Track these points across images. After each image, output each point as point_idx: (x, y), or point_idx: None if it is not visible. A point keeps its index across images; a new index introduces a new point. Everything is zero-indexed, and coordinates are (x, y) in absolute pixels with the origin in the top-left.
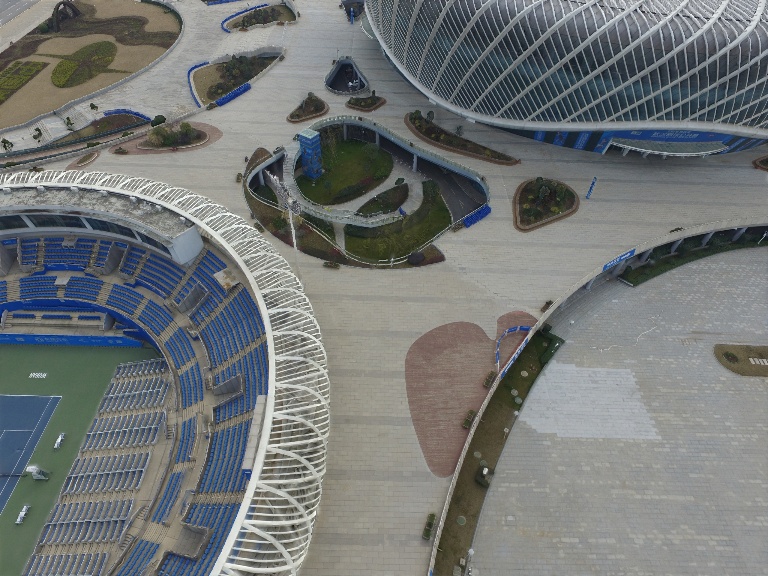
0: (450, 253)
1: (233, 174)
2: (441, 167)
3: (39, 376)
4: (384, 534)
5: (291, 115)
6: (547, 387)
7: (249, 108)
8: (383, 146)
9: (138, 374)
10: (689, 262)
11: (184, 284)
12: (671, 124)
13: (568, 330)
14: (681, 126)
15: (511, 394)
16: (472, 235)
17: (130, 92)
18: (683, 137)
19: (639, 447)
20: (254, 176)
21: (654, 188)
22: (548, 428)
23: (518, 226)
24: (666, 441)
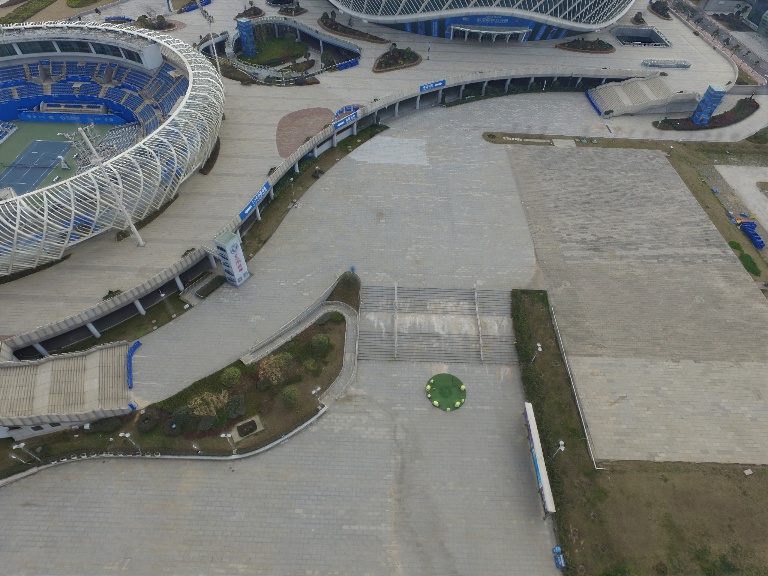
0: (324, 81)
1: (191, 44)
2: (341, 51)
3: None
4: (248, 174)
5: (236, 16)
6: (370, 145)
7: None
8: (303, 41)
9: (122, 131)
10: (491, 98)
11: (151, 83)
12: (484, 9)
13: (394, 124)
14: (490, 10)
15: (347, 148)
16: (342, 74)
17: (124, 9)
18: (498, 22)
19: (414, 167)
20: (206, 48)
21: (477, 56)
22: (363, 159)
23: (374, 70)
24: (431, 165)
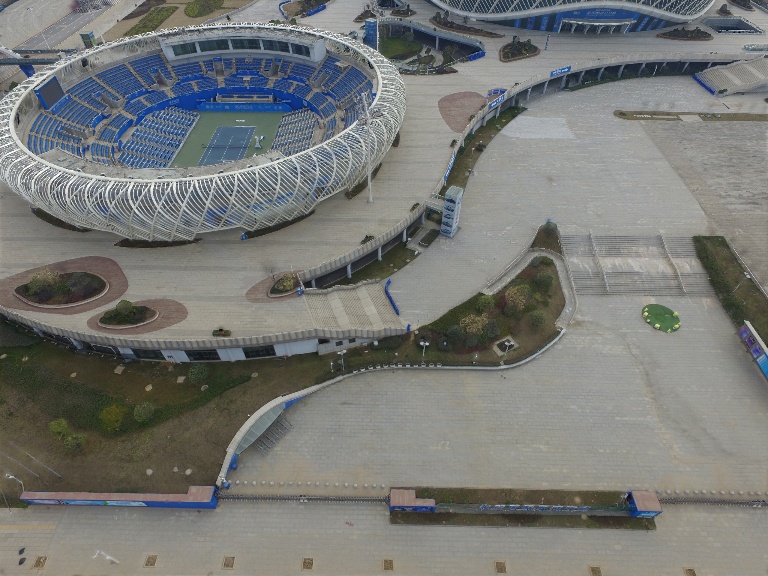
0: (461, 70)
1: None
2: (454, 47)
3: (241, 121)
4: (432, 145)
5: (356, 18)
6: (516, 123)
7: (328, 17)
8: (415, 39)
9: None
10: (608, 82)
11: (316, 74)
12: (596, 3)
13: (530, 106)
14: (602, 4)
15: (496, 126)
16: (474, 64)
17: (243, 16)
18: (607, 15)
19: (564, 141)
20: None
21: (589, 46)
22: (515, 135)
23: (501, 60)
24: (579, 139)
